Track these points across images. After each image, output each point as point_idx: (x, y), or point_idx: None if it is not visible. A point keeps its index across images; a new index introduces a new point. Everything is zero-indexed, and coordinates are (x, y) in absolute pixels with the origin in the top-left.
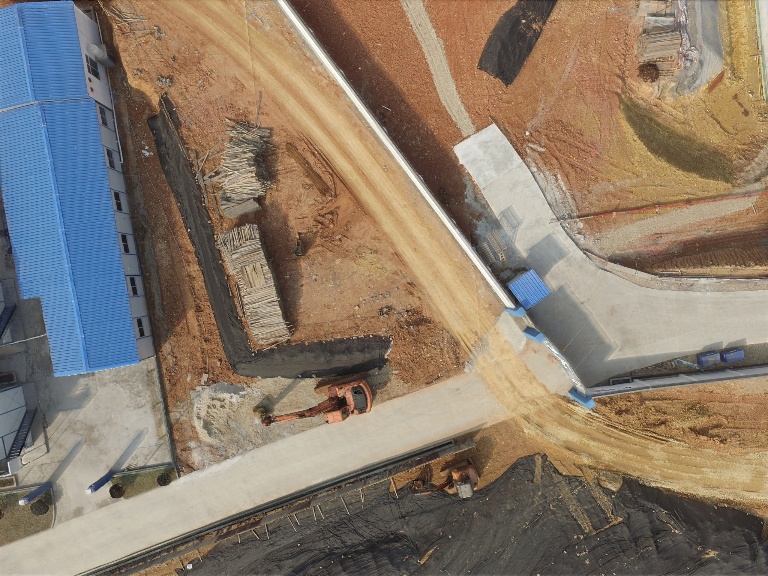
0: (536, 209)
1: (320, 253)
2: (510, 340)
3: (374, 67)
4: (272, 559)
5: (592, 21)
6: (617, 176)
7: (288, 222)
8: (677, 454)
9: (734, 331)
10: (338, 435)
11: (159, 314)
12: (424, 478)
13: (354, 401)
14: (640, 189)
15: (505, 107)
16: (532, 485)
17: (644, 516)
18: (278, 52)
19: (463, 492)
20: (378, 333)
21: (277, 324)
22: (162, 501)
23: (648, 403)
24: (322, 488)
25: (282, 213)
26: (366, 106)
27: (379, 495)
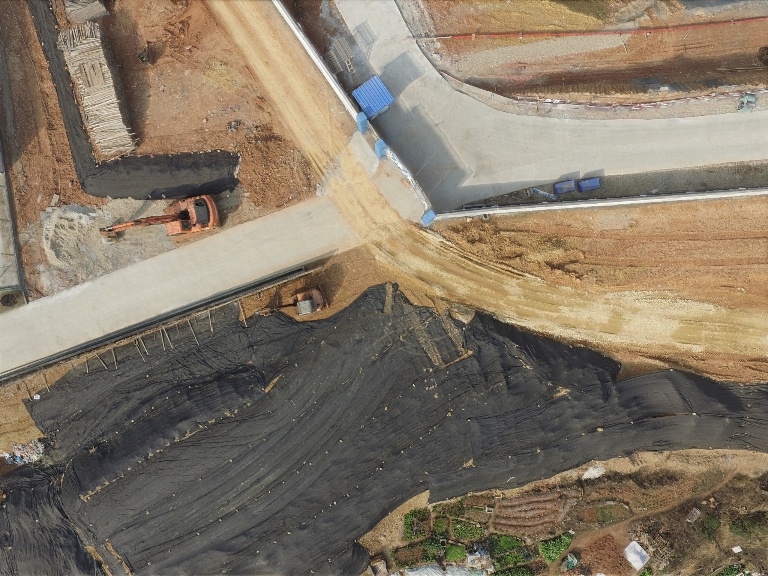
0: (392, 26)
1: (169, 63)
2: (362, 162)
3: None
4: (121, 391)
5: None
6: None
7: (137, 30)
8: (533, 290)
9: (592, 161)
10: (188, 260)
11: (11, 131)
12: (273, 306)
13: (196, 214)
14: (503, 15)
15: None
16: (382, 315)
17: (495, 350)
18: None
19: (302, 308)
20: (226, 148)
21: (118, 130)
22: (10, 327)
23: (503, 234)
24: (172, 316)
25: (131, 20)
26: None
27: (228, 324)
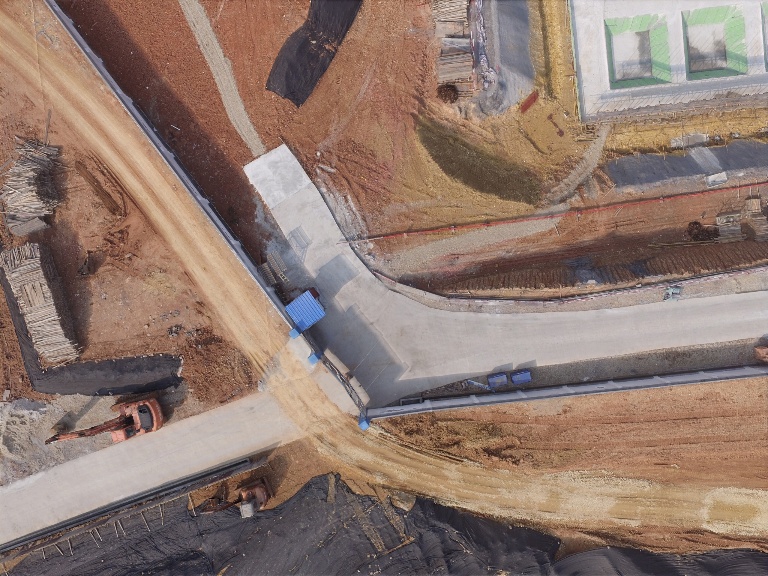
0: (325, 230)
1: (110, 271)
2: (301, 360)
3: (162, 86)
4: (77, 575)
5: (390, 42)
6: (410, 197)
7: (78, 240)
8: (472, 474)
9: (524, 353)
10: (137, 452)
11: None
12: (220, 496)
13: (140, 420)
14: (435, 210)
15: (296, 127)
16: (326, 504)
17: (436, 536)
18: (67, 70)
19: (244, 512)
20: (168, 352)
21: (61, 343)
22: None
23: (440, 423)
24: (123, 505)
25: (72, 231)
26: (142, 126)
27: (178, 512)
